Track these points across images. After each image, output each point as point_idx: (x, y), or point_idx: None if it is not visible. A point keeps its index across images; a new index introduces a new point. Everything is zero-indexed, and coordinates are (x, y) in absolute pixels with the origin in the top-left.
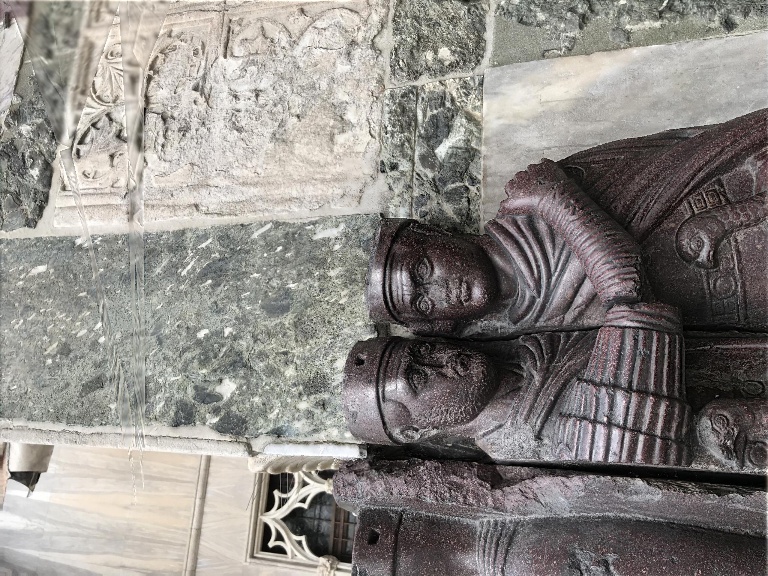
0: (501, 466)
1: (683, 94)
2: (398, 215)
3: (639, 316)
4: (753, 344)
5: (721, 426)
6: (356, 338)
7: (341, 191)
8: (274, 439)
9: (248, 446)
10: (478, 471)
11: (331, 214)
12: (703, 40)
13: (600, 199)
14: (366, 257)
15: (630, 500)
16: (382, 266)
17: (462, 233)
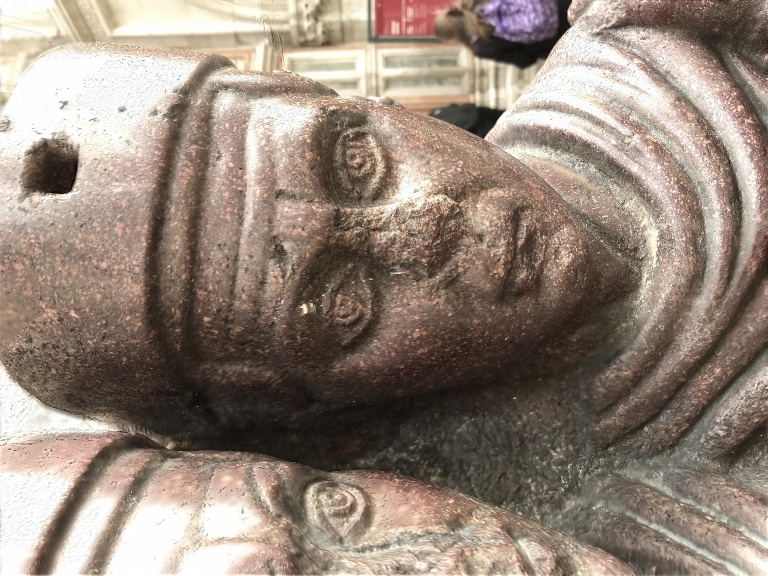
0: None
1: None
2: None
3: None
4: None
5: None
6: None
7: None
8: None
9: None
10: None
11: None
12: None
13: None
14: None
15: None
16: None
17: None
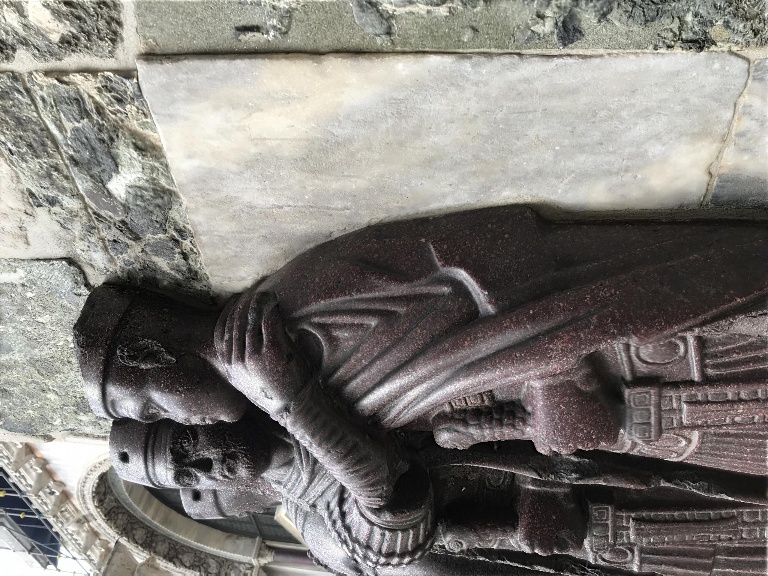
0: None
1: (474, 150)
2: (93, 259)
3: (385, 523)
4: None
5: None
6: None
7: None
8: (70, 432)
9: (48, 437)
10: None
11: None
12: (518, 59)
13: (344, 394)
14: (76, 309)
15: None
16: (104, 413)
17: None
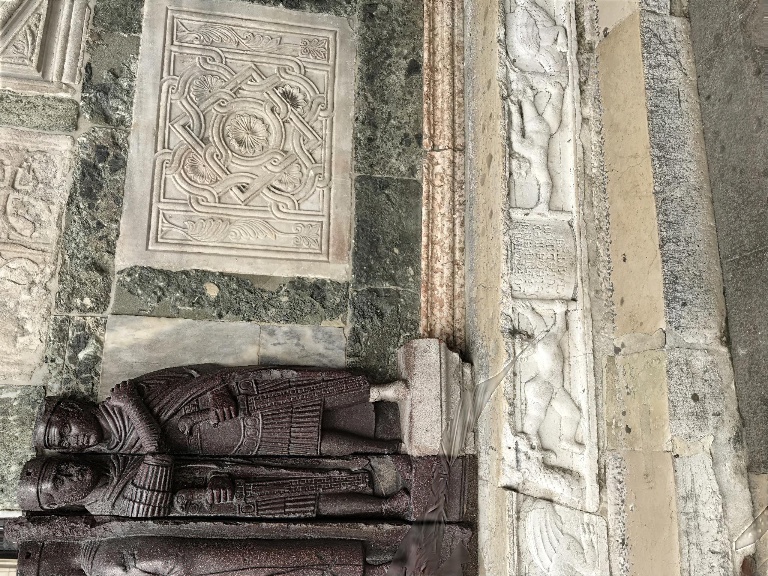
0: (96, 516)
1: (197, 345)
2: (53, 387)
3: (156, 460)
4: (201, 465)
5: (180, 500)
6: (24, 454)
7: (20, 371)
8: None
9: None
10: (85, 520)
11: (13, 384)
12: (209, 321)
13: (150, 404)
14: (33, 411)
15: (147, 529)
16: (45, 428)
17: (88, 402)
